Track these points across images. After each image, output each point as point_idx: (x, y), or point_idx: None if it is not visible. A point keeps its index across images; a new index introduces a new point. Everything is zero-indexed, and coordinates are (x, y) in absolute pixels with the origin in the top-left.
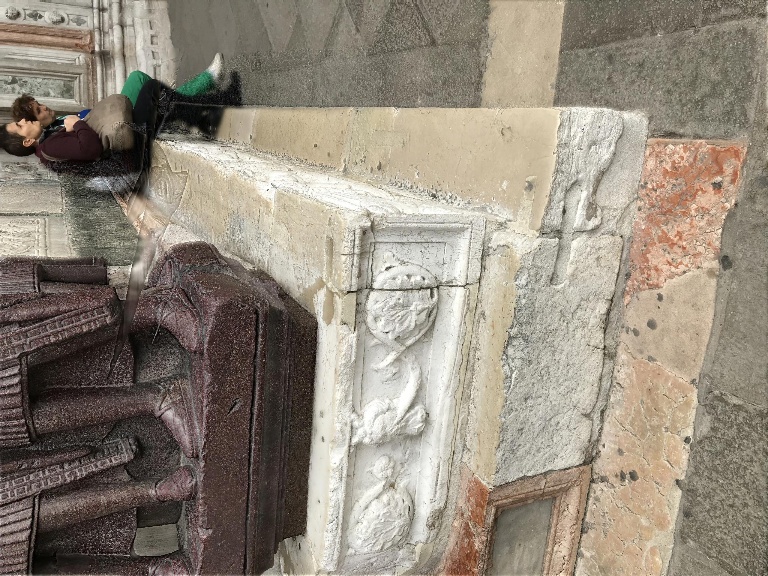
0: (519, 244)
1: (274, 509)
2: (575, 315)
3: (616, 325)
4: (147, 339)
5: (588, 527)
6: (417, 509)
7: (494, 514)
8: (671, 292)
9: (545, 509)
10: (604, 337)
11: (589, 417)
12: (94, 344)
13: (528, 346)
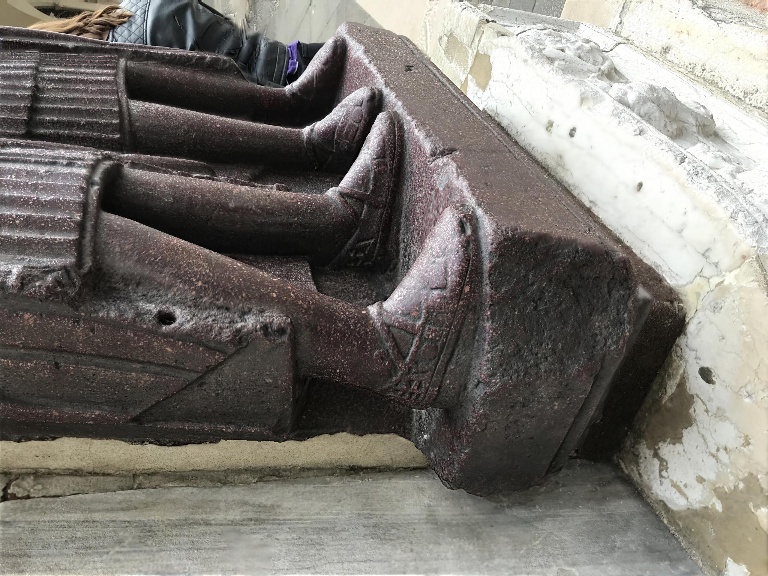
0: None
1: None
2: None
3: None
4: None
5: None
6: None
7: None
8: None
9: None
10: None
11: None
12: (210, 88)
13: None
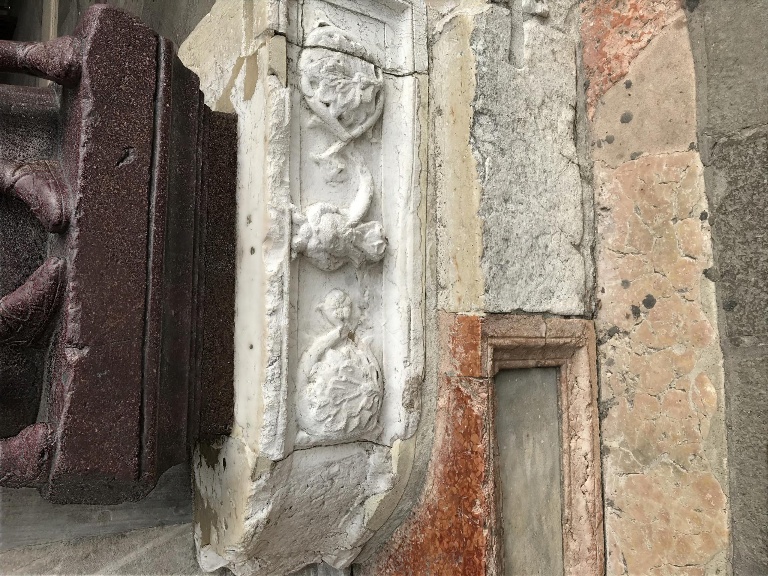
0: (468, 11)
1: (185, 361)
2: (541, 112)
3: (585, 144)
4: (2, 116)
5: (606, 408)
6: (387, 382)
7: (491, 358)
8: (639, 70)
9: (549, 387)
10: (576, 152)
11: (579, 251)
12: None
13: (497, 130)
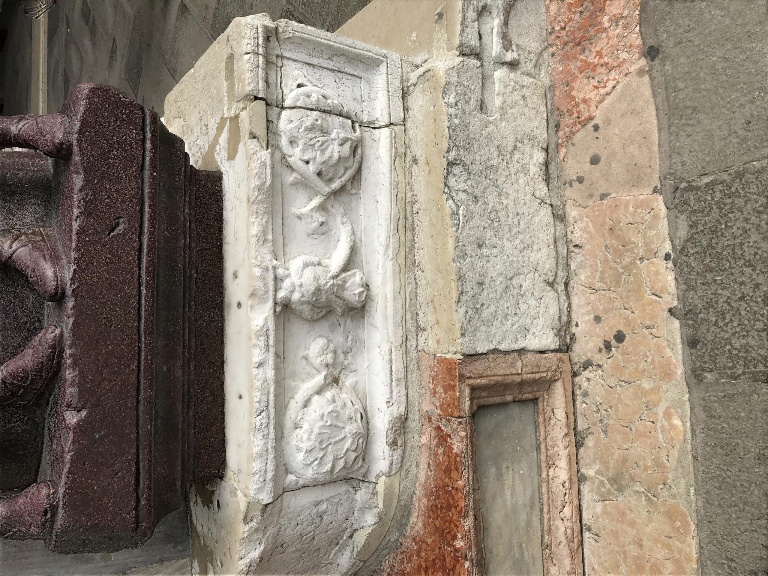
0: (440, 65)
1: (178, 413)
2: (513, 157)
3: (557, 184)
4: None
5: (583, 437)
6: (371, 422)
7: (469, 398)
8: (606, 115)
9: (527, 419)
10: (548, 193)
11: (553, 288)
12: None
13: (470, 178)
